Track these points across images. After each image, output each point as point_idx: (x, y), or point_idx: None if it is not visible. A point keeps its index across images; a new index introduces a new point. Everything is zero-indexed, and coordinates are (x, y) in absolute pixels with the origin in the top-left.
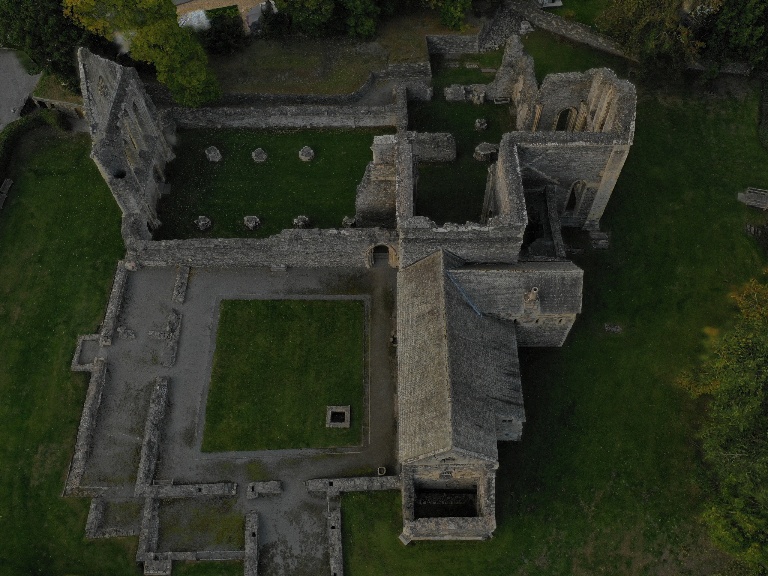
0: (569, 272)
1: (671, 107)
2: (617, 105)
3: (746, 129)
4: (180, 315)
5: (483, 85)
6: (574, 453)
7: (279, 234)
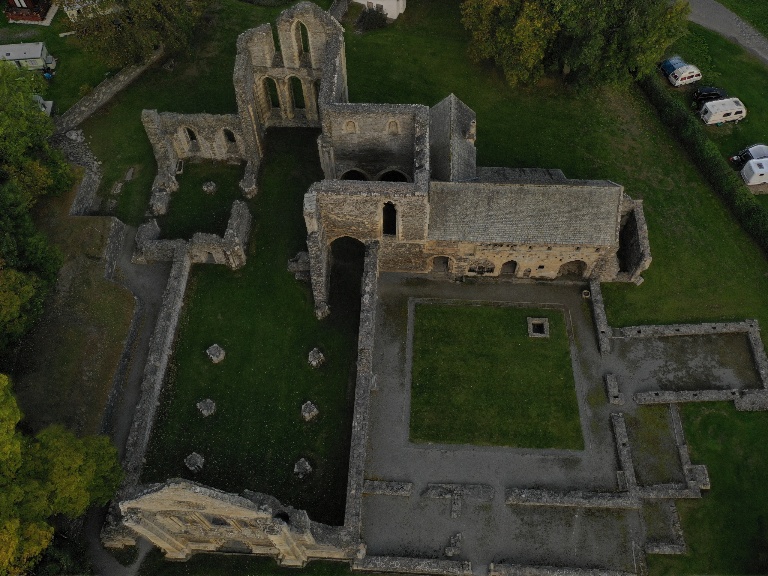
0: (453, 102)
1: (220, 50)
2: (317, 19)
3: (256, 11)
4: (429, 486)
5: (157, 177)
6: (557, 166)
7: (360, 354)
